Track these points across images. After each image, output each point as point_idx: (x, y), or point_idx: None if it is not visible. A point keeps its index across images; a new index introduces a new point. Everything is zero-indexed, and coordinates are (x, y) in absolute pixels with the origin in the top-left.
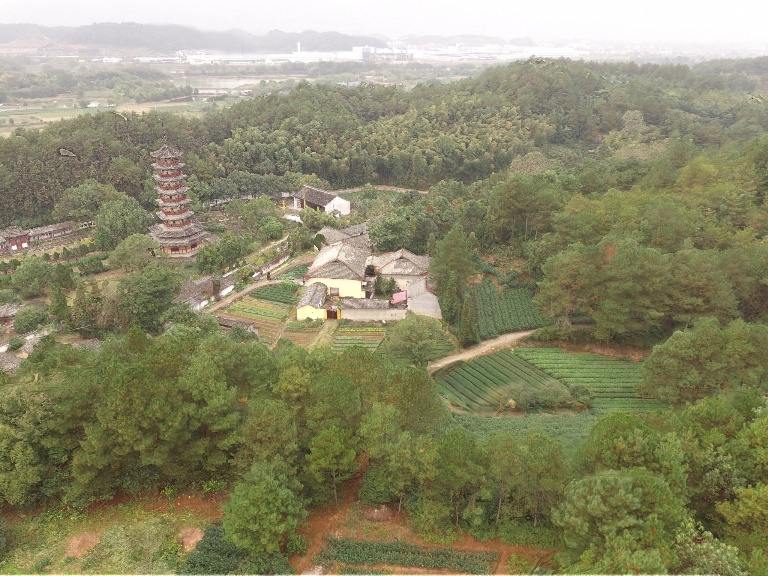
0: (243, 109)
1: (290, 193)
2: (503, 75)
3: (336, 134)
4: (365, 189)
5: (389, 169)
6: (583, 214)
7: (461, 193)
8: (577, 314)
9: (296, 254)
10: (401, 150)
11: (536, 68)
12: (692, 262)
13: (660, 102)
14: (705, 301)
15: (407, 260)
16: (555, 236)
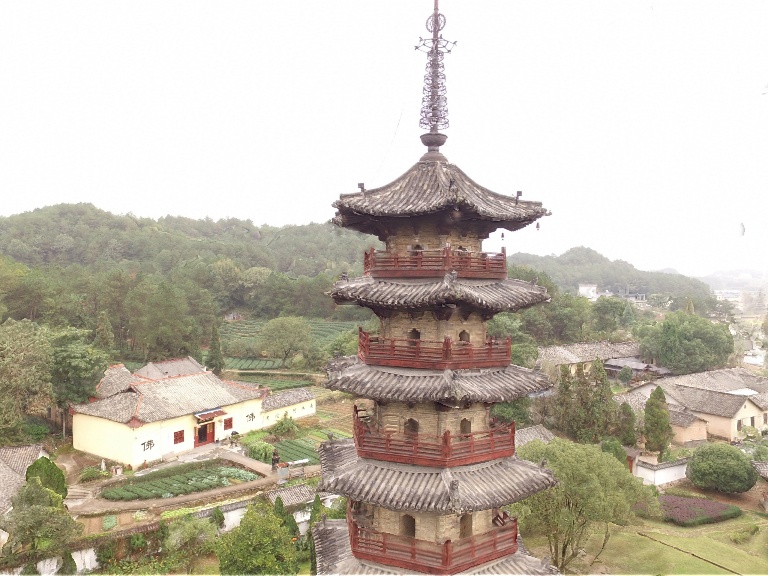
0: None
1: None
2: None
3: None
4: None
5: None
6: None
7: None
8: None
9: None
10: None
11: None
12: None
13: None
14: None
15: None
16: None
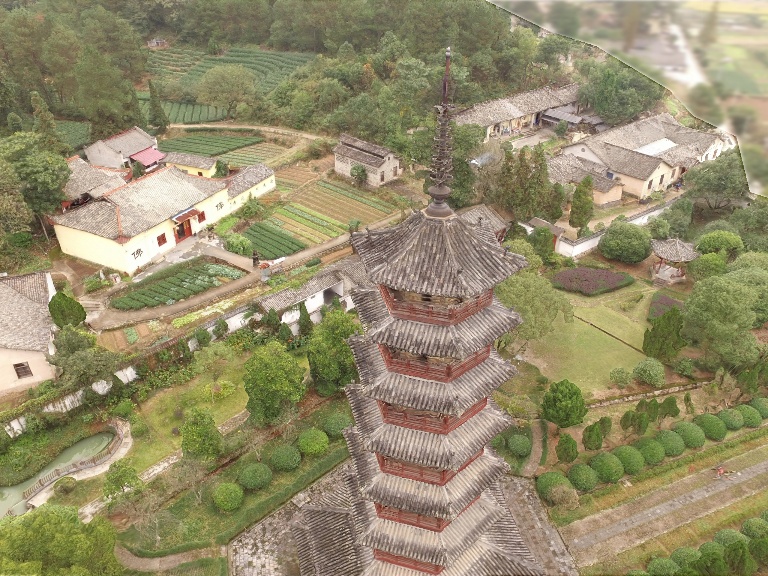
0: None
1: None
2: None
3: None
4: None
5: None
6: None
7: None
8: None
9: None
10: None
11: None
12: None
13: None
14: None
15: None
16: None
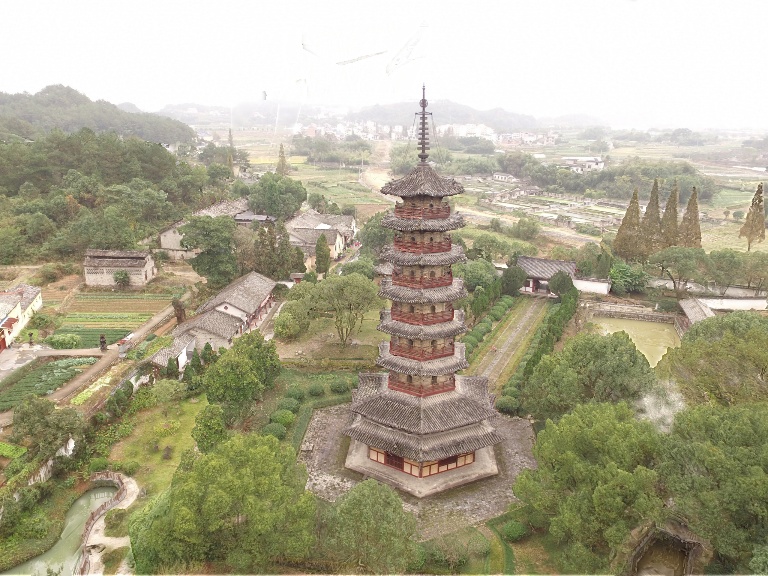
0: None
1: None
2: None
3: None
4: None
5: None
6: None
7: None
8: None
9: None
10: None
11: None
12: None
13: None
14: None
15: None
16: None
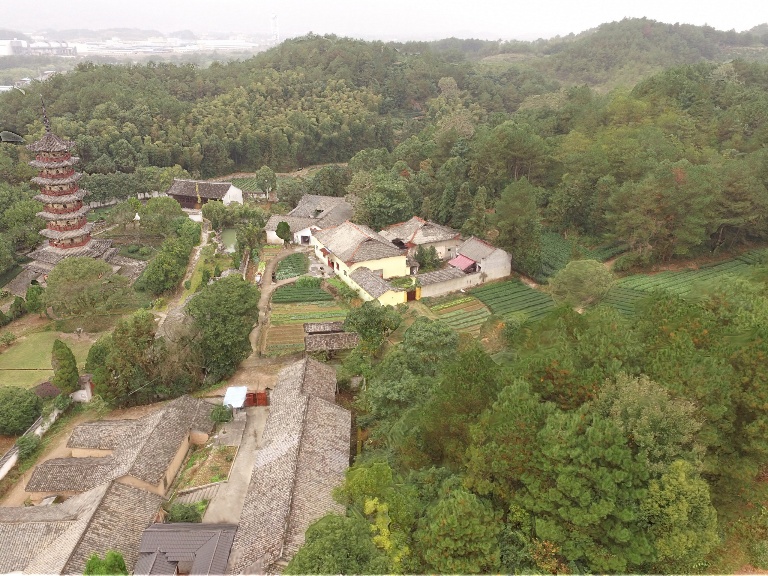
0: (22, 98)
1: (149, 192)
2: (305, 50)
3: (171, 119)
4: (264, 172)
5: (242, 154)
6: (597, 150)
7: (387, 160)
8: (620, 243)
9: (257, 251)
10: (253, 131)
11: (332, 42)
12: (735, 172)
13: (458, 69)
14: (751, 203)
15: (431, 226)
16: (582, 174)
